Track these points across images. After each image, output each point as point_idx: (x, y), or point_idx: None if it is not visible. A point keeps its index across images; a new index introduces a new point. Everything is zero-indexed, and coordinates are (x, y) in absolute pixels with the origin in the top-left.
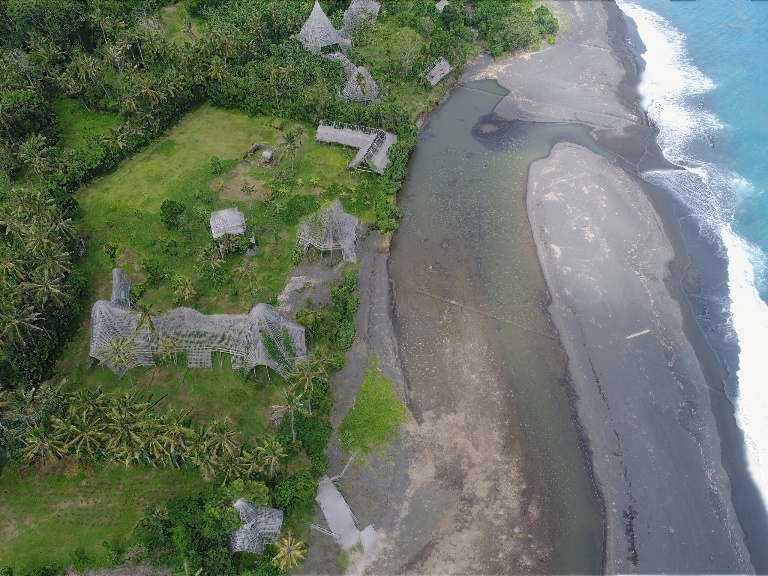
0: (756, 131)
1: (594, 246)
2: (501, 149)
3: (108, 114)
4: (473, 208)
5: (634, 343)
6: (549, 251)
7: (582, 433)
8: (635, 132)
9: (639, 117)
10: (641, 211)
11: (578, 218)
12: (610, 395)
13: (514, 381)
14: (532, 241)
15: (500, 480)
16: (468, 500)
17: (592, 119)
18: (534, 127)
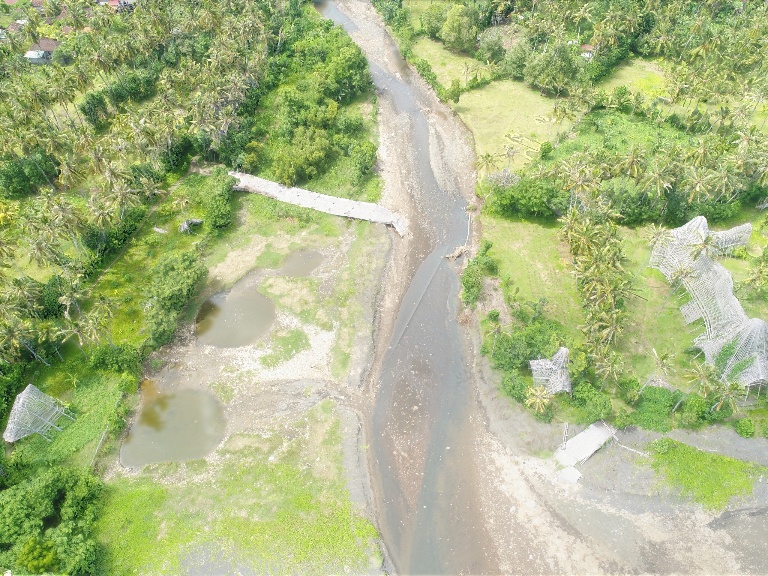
0: None
1: None
2: None
3: None
4: None
5: None
6: None
7: None
8: None
9: None
10: None
11: None
12: None
13: None
14: None
15: None
16: None
17: None
18: None
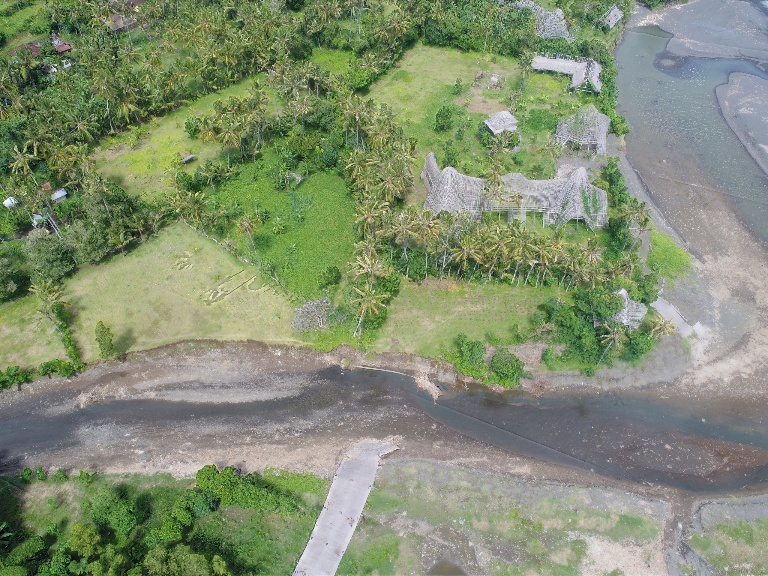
0: None
1: None
2: (685, 78)
3: (339, 51)
4: (680, 120)
5: None
6: (759, 149)
7: None
8: None
9: None
10: None
11: None
12: None
13: (765, 236)
14: (740, 143)
15: None
16: (763, 309)
17: (756, 55)
18: (706, 61)
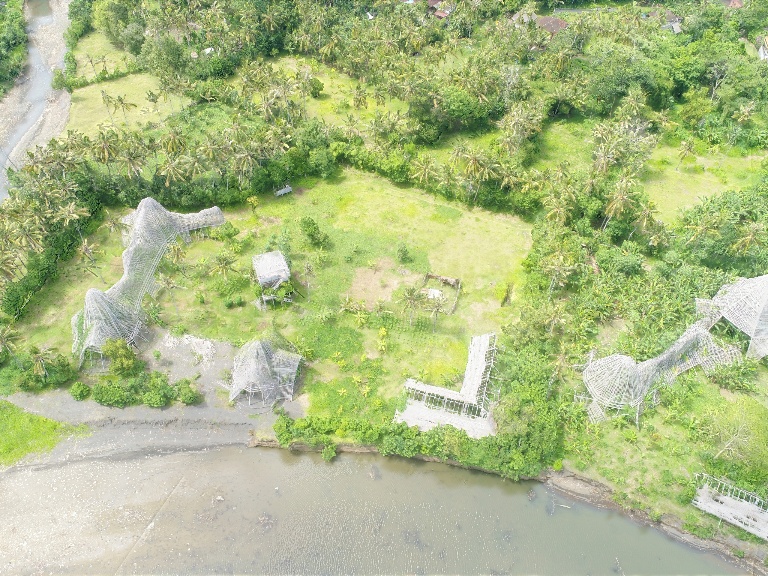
0: None
1: None
2: None
3: None
4: (348, 570)
5: None
6: None
7: None
8: None
9: None
10: None
11: None
12: None
13: None
14: None
15: None
16: None
17: None
18: None
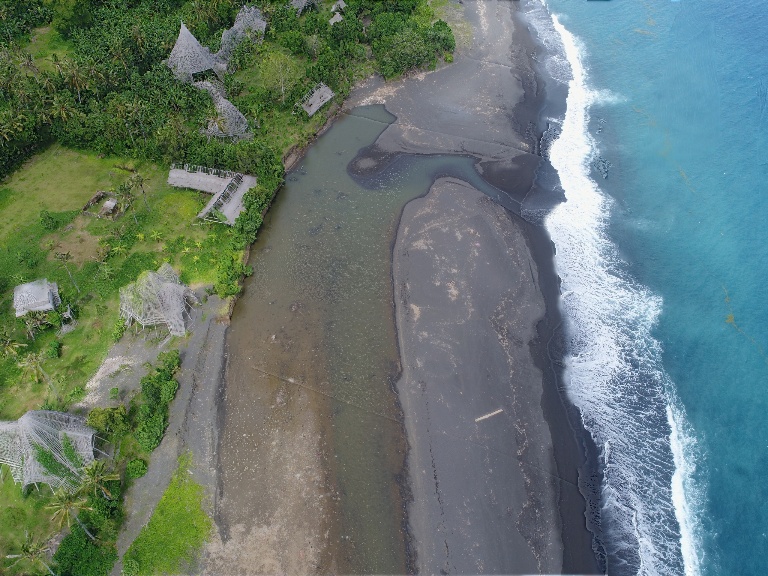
0: (652, 159)
1: (456, 305)
2: (376, 187)
3: None
4: (334, 261)
5: (483, 427)
6: (408, 312)
7: (410, 545)
8: (524, 163)
9: (531, 145)
10: (516, 259)
11: (444, 271)
12: (446, 496)
13: (344, 479)
14: (392, 300)
15: None
16: None
17: (479, 149)
18: (416, 160)
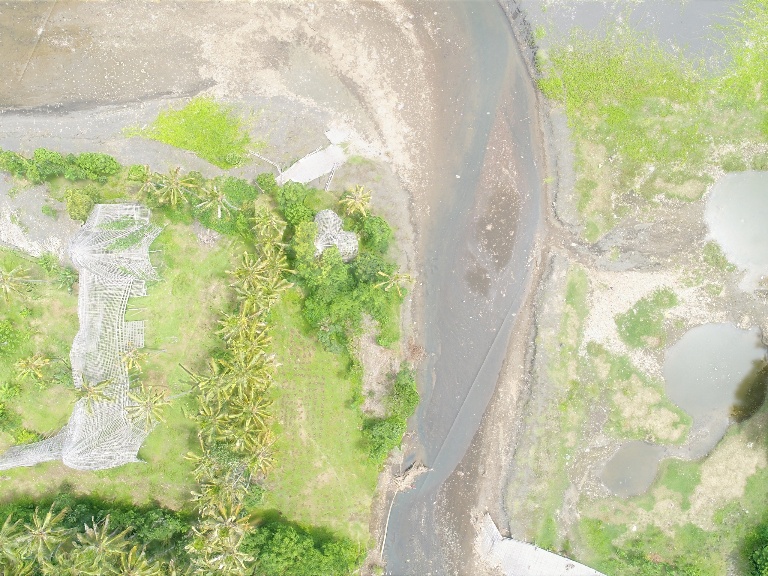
0: None
1: None
2: None
3: None
4: None
5: None
6: None
7: None
8: None
9: None
10: None
11: None
12: None
13: None
14: None
15: (279, 3)
16: (300, 38)
17: None
18: None
